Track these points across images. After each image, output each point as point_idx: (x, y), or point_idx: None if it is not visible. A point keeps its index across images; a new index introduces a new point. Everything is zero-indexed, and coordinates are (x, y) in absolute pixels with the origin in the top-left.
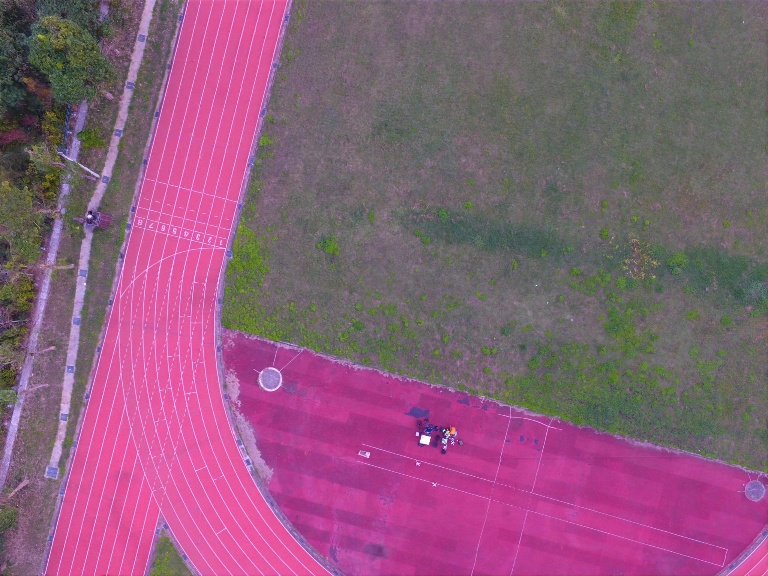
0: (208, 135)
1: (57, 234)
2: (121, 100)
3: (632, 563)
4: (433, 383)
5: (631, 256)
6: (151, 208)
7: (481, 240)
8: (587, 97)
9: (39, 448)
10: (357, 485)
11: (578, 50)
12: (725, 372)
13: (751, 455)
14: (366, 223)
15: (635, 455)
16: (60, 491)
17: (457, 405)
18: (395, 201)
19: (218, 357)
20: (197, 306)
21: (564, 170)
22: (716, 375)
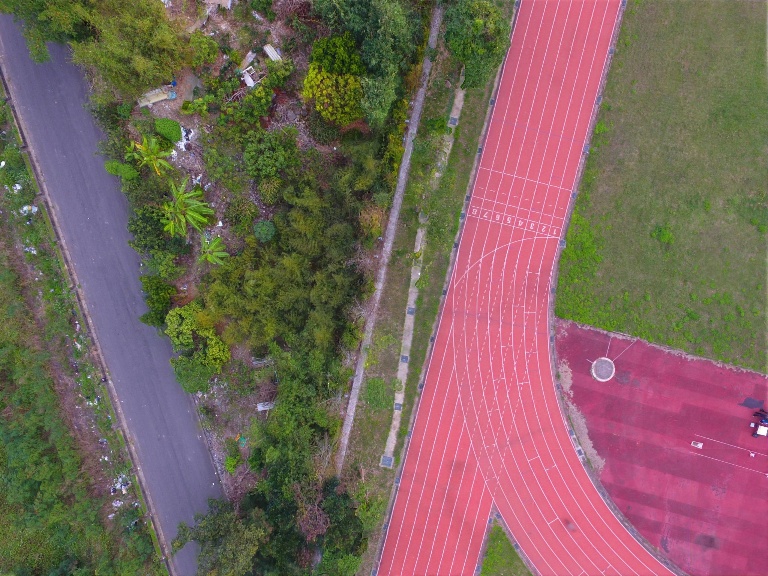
0: (543, 123)
1: (393, 224)
2: (457, 88)
3: None
4: (767, 373)
5: None
6: (486, 197)
7: None
8: None
9: (374, 437)
10: (689, 476)
11: None
12: None
13: None
14: (701, 211)
15: None
16: (395, 480)
17: None
18: (731, 189)
19: (551, 347)
20: (530, 296)
21: None
22: None
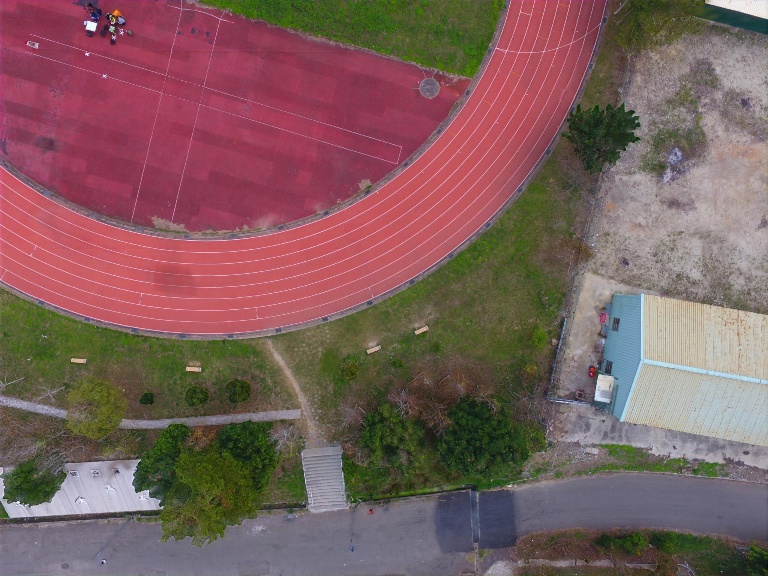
0: None
1: None
2: None
3: (306, 159)
4: None
5: None
6: None
7: None
8: None
9: None
10: (26, 76)
11: None
12: None
13: (425, 51)
14: None
15: (309, 50)
16: None
17: None
18: None
19: None
20: None
21: None
22: None
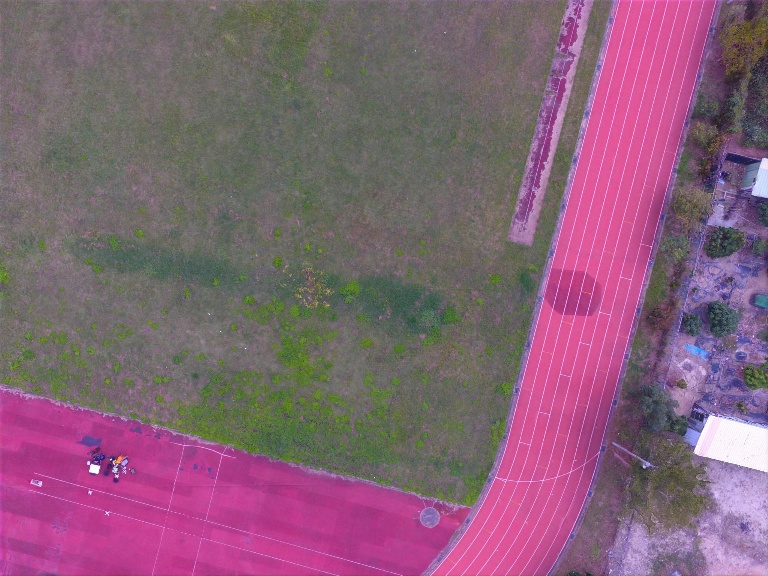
0: None
1: None
2: None
3: None
4: (105, 412)
5: (305, 284)
6: None
7: (152, 269)
8: (259, 125)
9: None
10: (29, 514)
11: (249, 78)
12: (399, 400)
13: (426, 482)
14: (36, 252)
15: (310, 483)
16: None
17: (130, 434)
18: (66, 229)
19: None
20: None
21: (236, 198)
22: (390, 403)
